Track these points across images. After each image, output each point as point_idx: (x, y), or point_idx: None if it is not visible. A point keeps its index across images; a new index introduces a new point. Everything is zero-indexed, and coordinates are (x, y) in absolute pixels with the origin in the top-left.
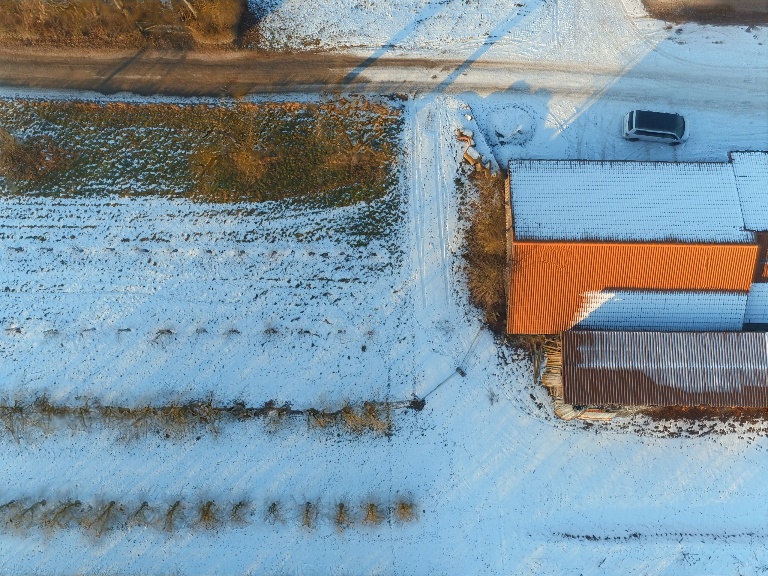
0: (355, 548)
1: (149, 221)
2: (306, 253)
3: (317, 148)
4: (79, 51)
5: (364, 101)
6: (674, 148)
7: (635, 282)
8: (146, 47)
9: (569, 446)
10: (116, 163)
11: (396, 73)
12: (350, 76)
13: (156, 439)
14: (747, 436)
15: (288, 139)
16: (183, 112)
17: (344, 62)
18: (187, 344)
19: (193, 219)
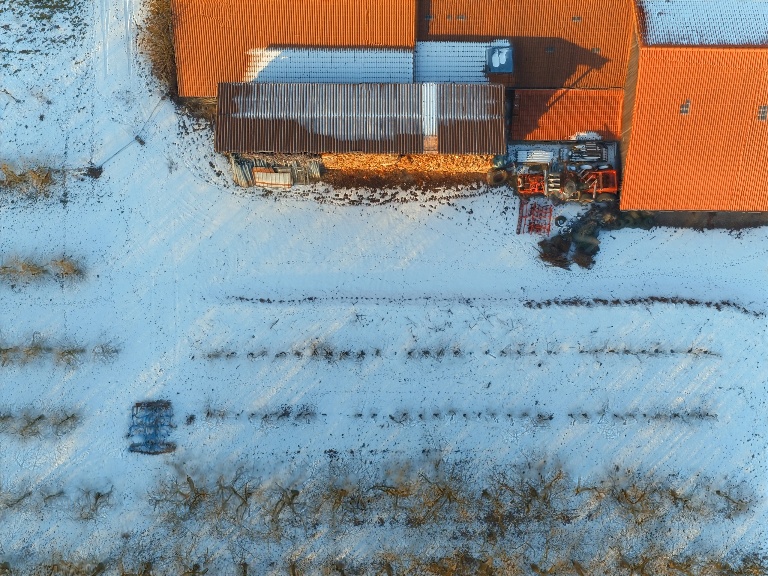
0: (26, 311)
1: None
2: None
3: None
4: None
5: None
6: None
7: (298, 38)
8: None
9: (247, 213)
10: None
11: None
12: None
13: None
14: (429, 204)
15: None
16: None
17: None
18: None
19: None
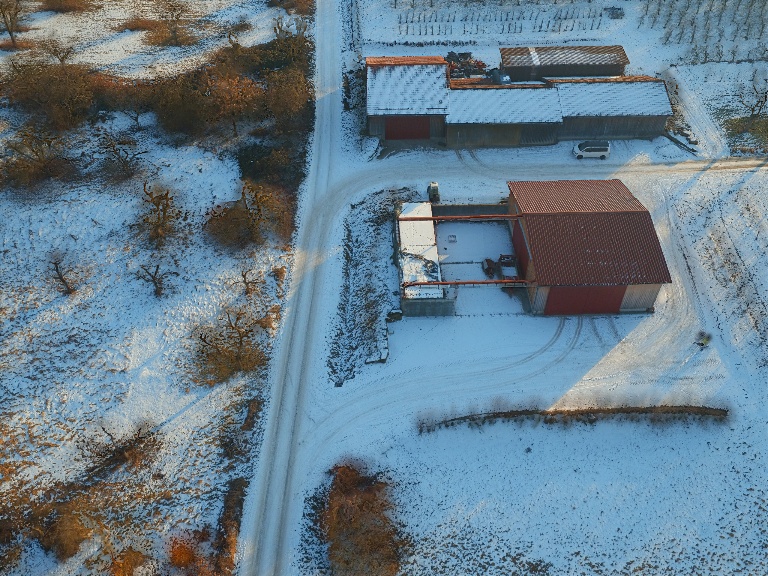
0: None
1: None
2: None
3: None
4: None
5: None
6: None
7: None
8: None
9: None
10: None
11: (743, 163)
12: None
13: None
14: None
15: None
16: None
17: None
18: None
19: None
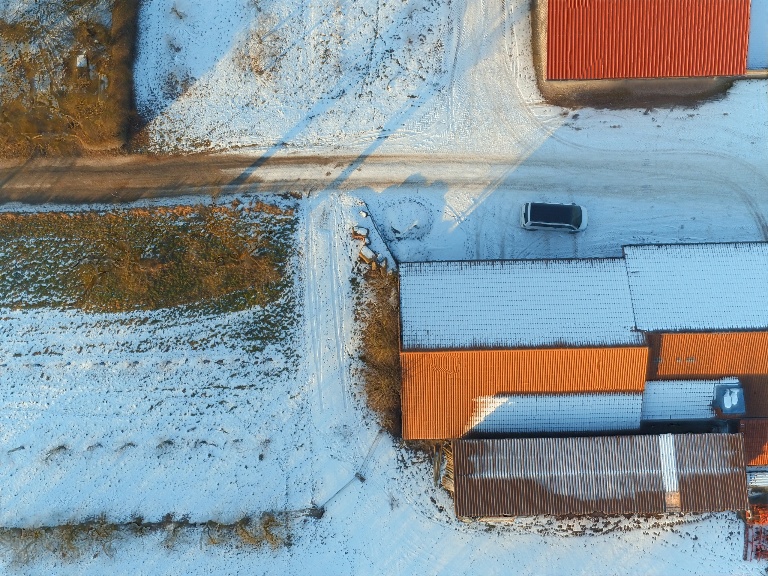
0: None
1: (41, 334)
2: (201, 361)
3: (210, 253)
4: None
5: (258, 201)
6: (574, 236)
7: (527, 386)
8: (35, 156)
9: (471, 549)
10: (7, 276)
11: (289, 171)
12: (243, 176)
13: (52, 559)
14: (652, 531)
15: (180, 245)
16: (74, 221)
17: (236, 162)
18: (82, 460)
19: (86, 331)
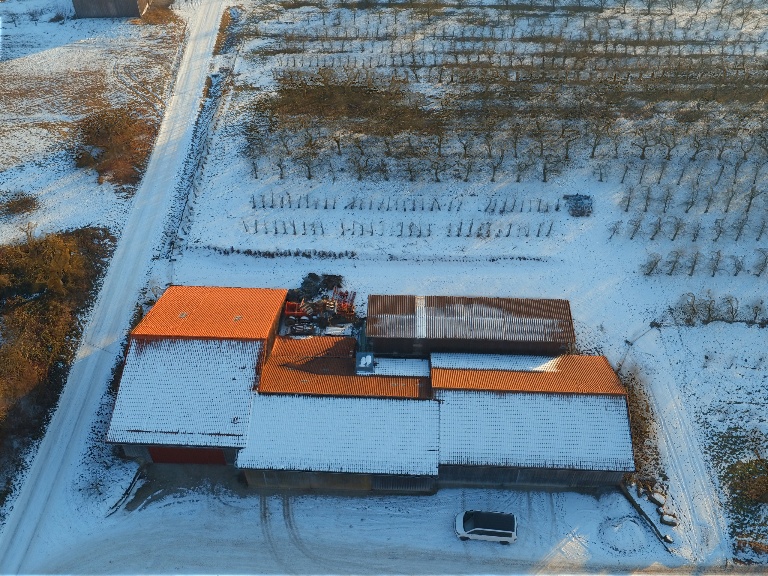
0: None
1: None
2: None
3: None
4: None
5: None
6: None
7: None
8: None
9: None
10: None
11: None
12: None
13: None
14: None
15: None
16: None
17: None
18: None
19: None
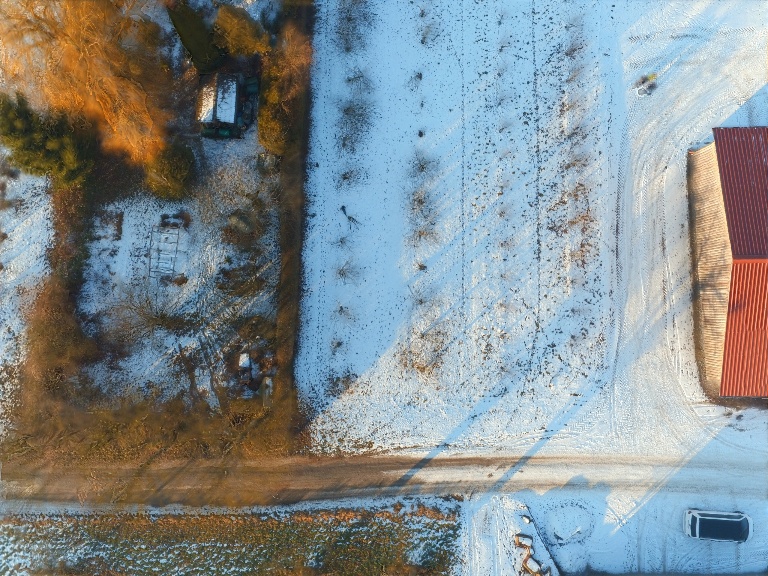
0: None
1: None
2: None
3: (373, 561)
4: (128, 463)
5: (419, 504)
6: None
7: None
8: (196, 457)
9: None
10: None
11: (451, 473)
12: (404, 478)
13: None
14: None
15: (343, 552)
16: (235, 526)
17: (398, 464)
18: None
19: None
